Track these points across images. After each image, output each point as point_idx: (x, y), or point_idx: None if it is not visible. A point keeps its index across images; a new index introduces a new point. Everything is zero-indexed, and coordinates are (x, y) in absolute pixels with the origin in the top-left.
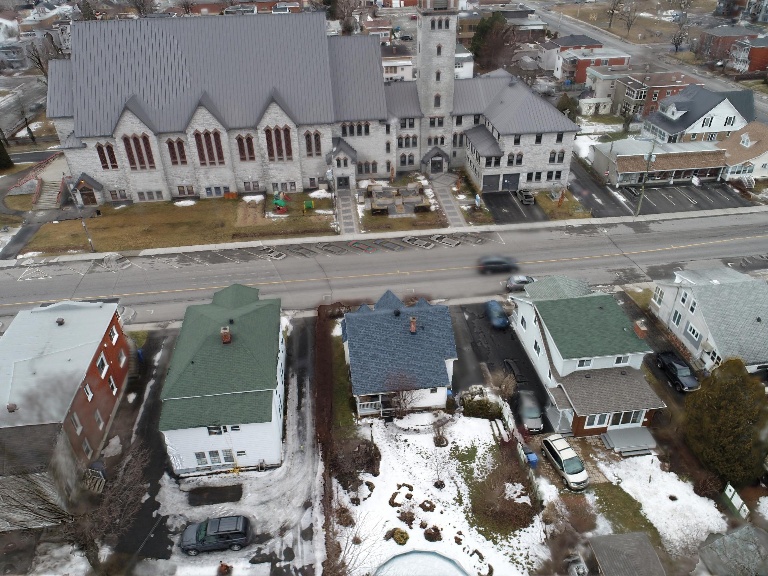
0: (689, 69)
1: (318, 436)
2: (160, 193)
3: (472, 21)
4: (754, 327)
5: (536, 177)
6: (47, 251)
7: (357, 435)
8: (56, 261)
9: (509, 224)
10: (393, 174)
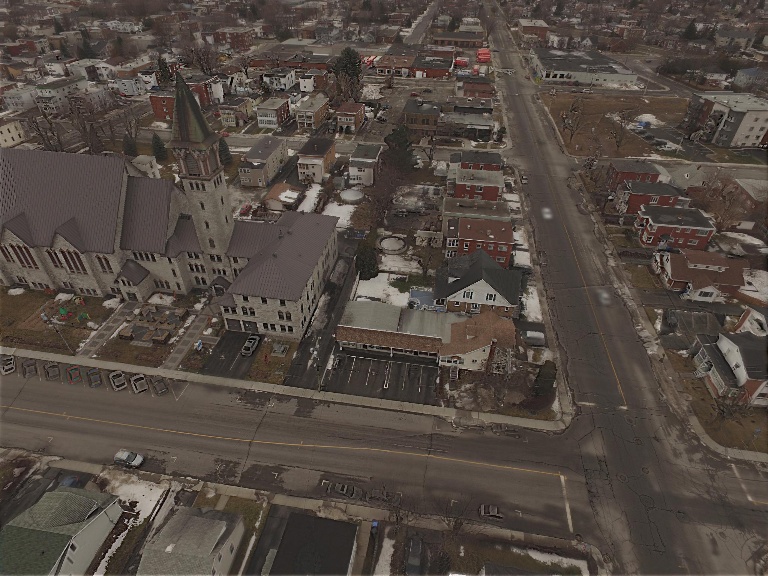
0: (580, 198)
1: None
2: (2, 280)
3: (425, 116)
4: None
5: (272, 327)
6: None
7: None
8: None
9: (208, 375)
10: None
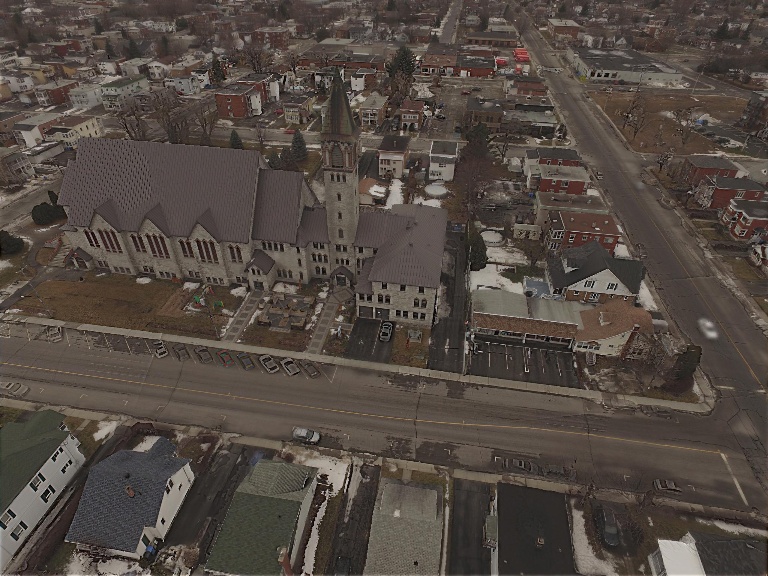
0: (658, 193)
1: (18, 572)
2: (129, 269)
3: (490, 114)
4: (407, 570)
5: (404, 314)
6: (25, 310)
7: (64, 569)
8: (24, 322)
9: (353, 359)
10: (305, 282)
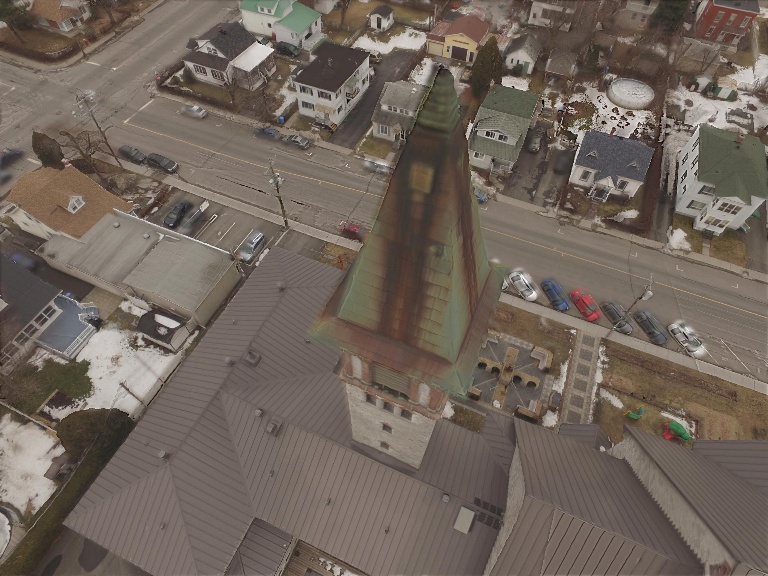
0: None
1: None
2: None
3: None
4: None
5: None
6: None
7: None
8: None
9: None
10: None
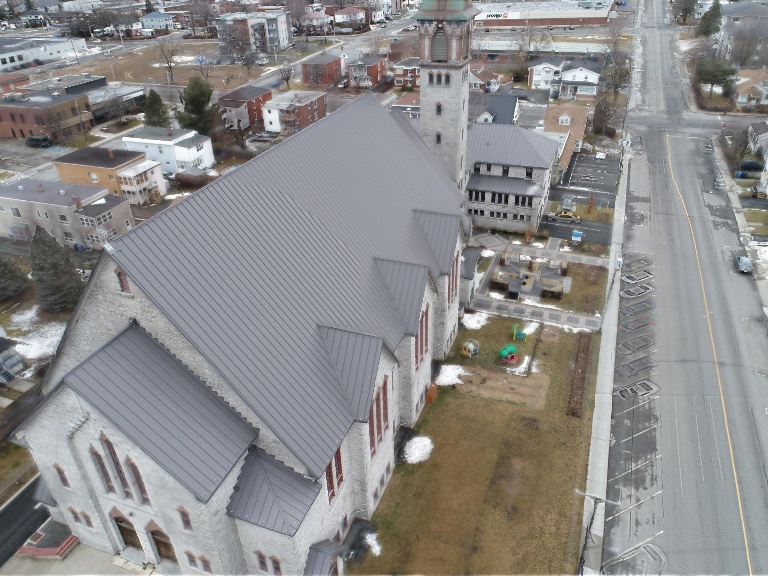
0: (329, 96)
1: None
2: (387, 466)
3: (73, 103)
4: None
5: None
6: None
7: None
8: None
9: None
10: None
